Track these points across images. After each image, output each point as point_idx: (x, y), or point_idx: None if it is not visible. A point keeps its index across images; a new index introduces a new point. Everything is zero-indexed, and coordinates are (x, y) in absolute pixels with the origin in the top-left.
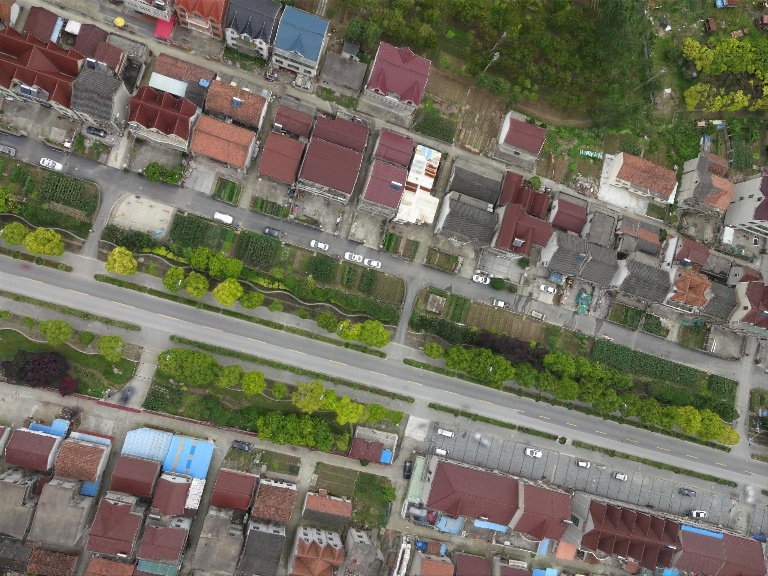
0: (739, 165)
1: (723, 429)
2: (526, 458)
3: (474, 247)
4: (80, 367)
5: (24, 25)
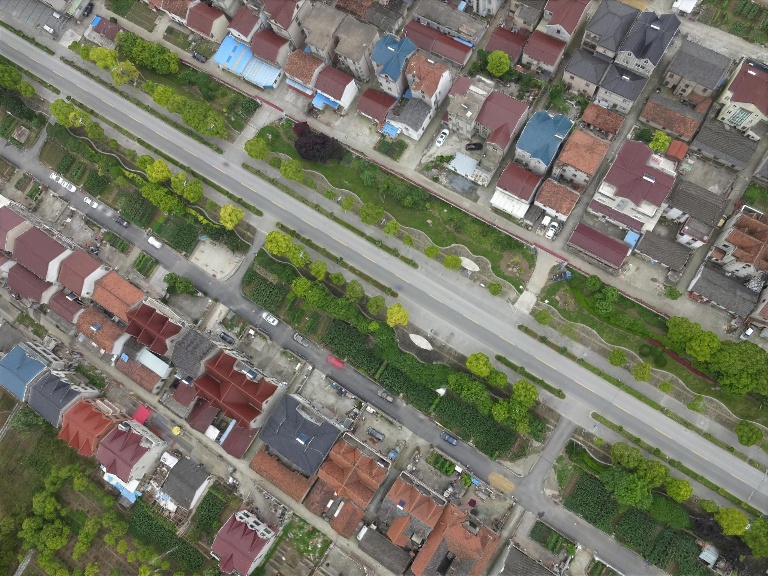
0: None
1: None
2: None
3: None
4: None
5: None
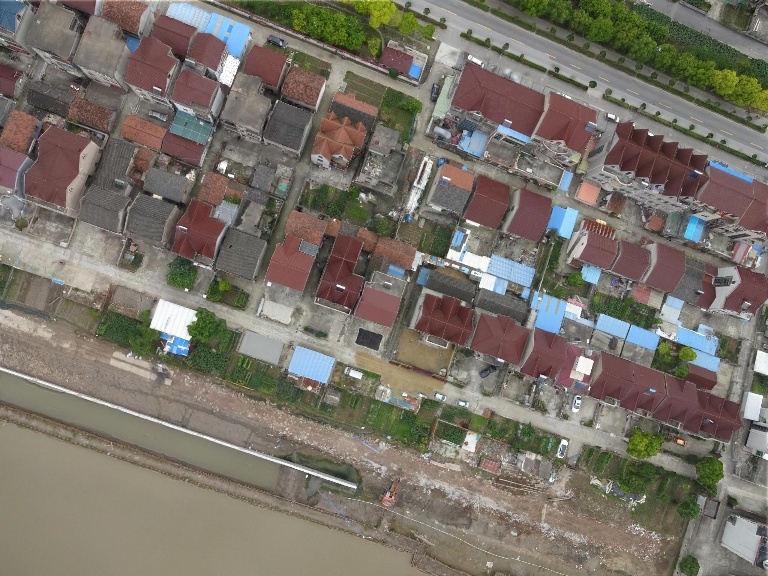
0: None
1: (761, 92)
2: None
3: None
4: None
5: None
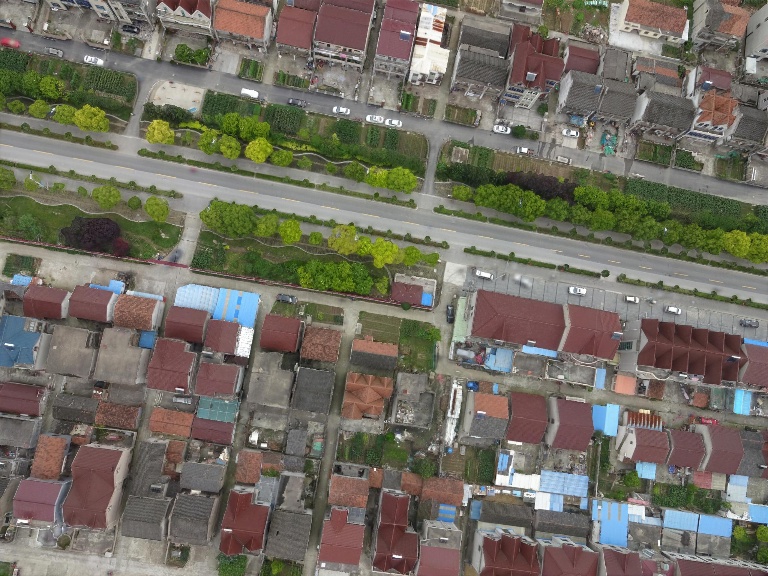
0: (752, 0)
1: None
2: (570, 297)
3: (491, 101)
4: (131, 234)
5: None
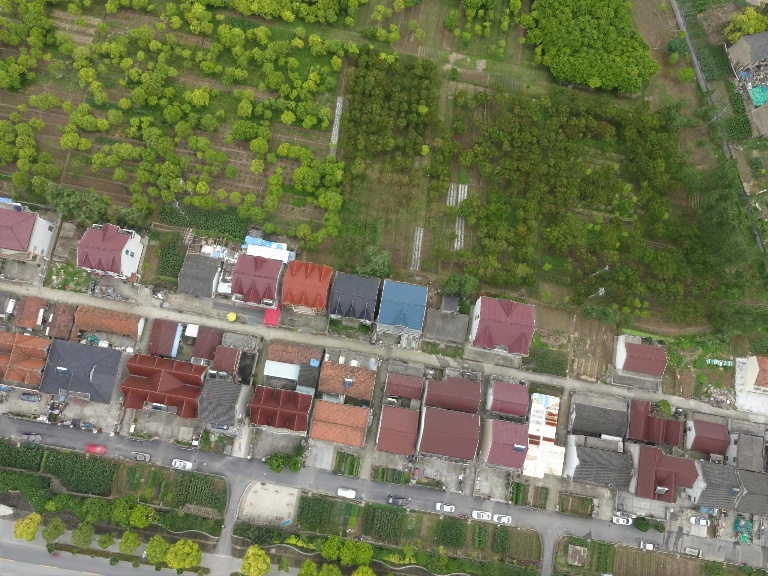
0: None
1: None
2: None
3: None
4: None
5: (150, 337)
